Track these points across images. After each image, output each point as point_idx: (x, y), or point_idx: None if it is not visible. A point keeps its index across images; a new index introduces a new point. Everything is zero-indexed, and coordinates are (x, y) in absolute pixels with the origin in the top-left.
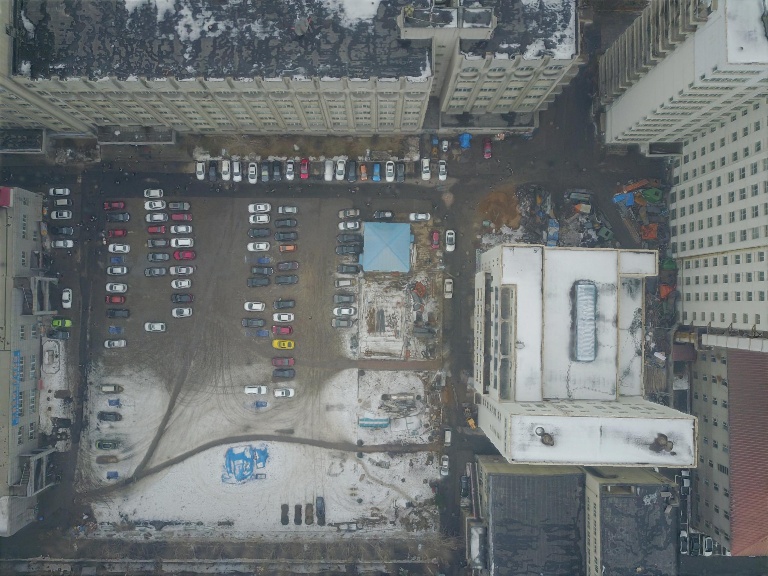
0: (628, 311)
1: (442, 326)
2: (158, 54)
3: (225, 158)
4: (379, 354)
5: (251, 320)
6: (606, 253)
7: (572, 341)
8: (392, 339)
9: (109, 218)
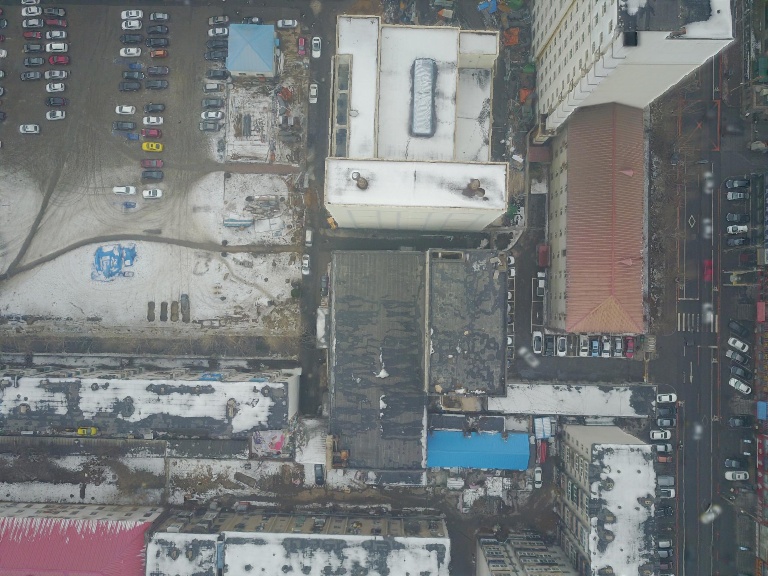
0: (477, 101)
1: (307, 131)
2: None
3: None
4: (245, 158)
5: (121, 122)
6: (447, 32)
7: (411, 117)
8: (258, 143)
9: None
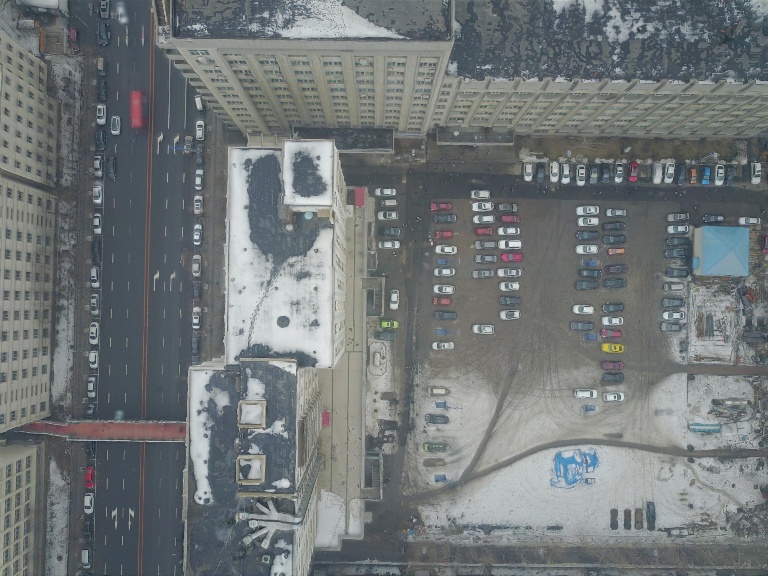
0: None
1: None
2: (586, 55)
3: (552, 160)
4: (708, 359)
5: (582, 323)
6: None
7: None
8: (721, 344)
9: (437, 219)
